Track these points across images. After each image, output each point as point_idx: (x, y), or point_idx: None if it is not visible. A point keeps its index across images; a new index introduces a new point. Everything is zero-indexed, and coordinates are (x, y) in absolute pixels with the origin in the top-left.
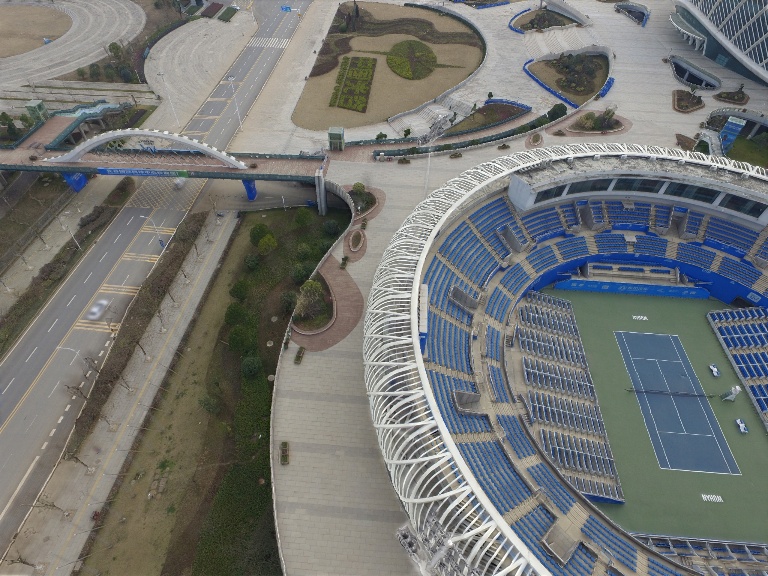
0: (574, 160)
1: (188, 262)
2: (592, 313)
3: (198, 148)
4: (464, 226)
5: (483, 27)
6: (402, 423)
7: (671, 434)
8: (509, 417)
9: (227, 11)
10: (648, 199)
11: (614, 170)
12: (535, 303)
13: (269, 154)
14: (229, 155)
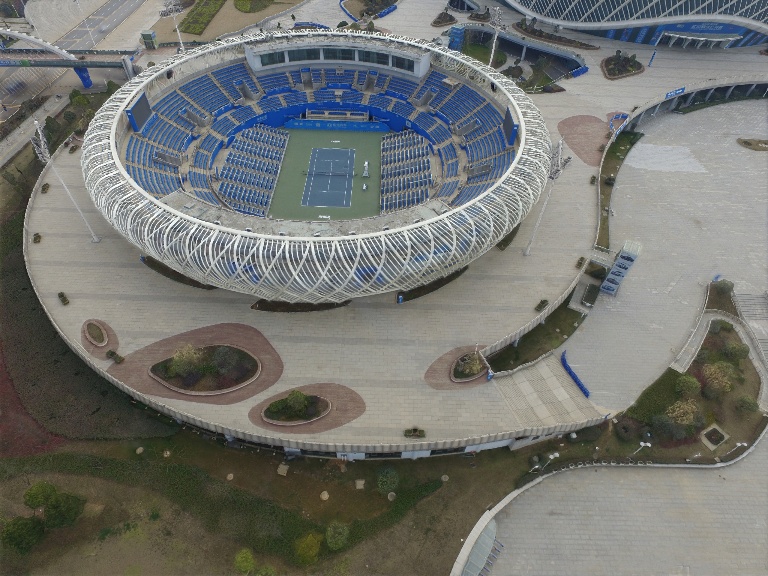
0: (294, 37)
1: (26, 122)
2: (303, 140)
3: (35, 43)
4: (206, 78)
5: None
6: (91, 141)
7: (318, 192)
8: (199, 173)
9: None
10: (353, 67)
11: (318, 42)
12: (260, 131)
13: (96, 50)
14: (61, 49)
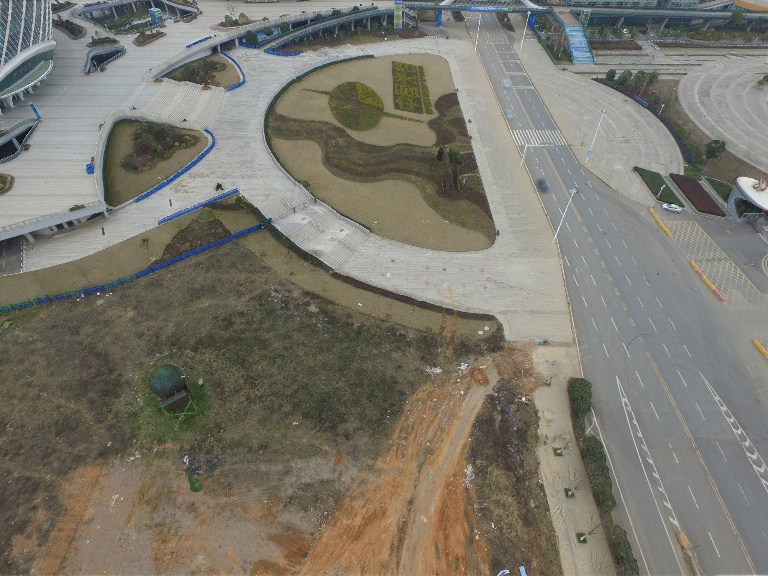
0: None
1: None
2: None
3: None
4: None
5: (254, 141)
6: None
7: None
8: None
9: (667, 190)
10: None
11: None
12: None
13: (431, 5)
14: None
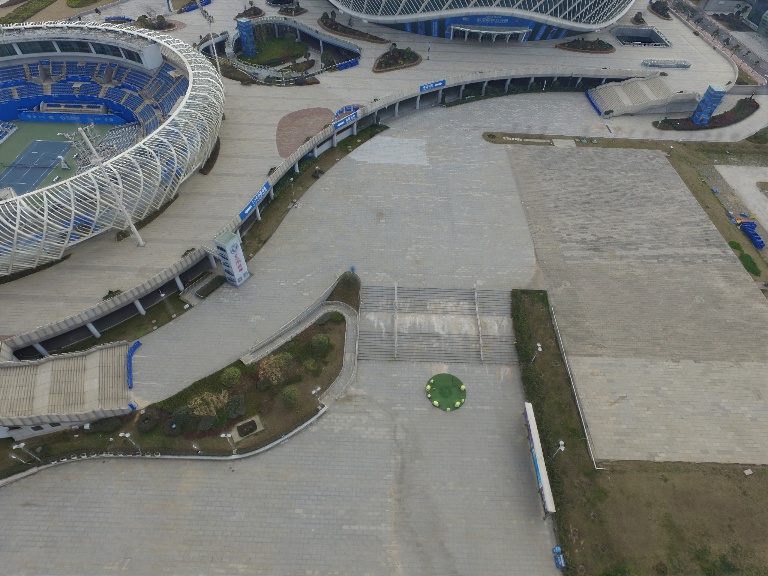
0: (28, 30)
1: None
2: (31, 132)
3: None
4: None
5: None
6: None
7: (5, 184)
8: None
9: None
10: (96, 60)
11: (48, 34)
12: None
13: None
14: None
